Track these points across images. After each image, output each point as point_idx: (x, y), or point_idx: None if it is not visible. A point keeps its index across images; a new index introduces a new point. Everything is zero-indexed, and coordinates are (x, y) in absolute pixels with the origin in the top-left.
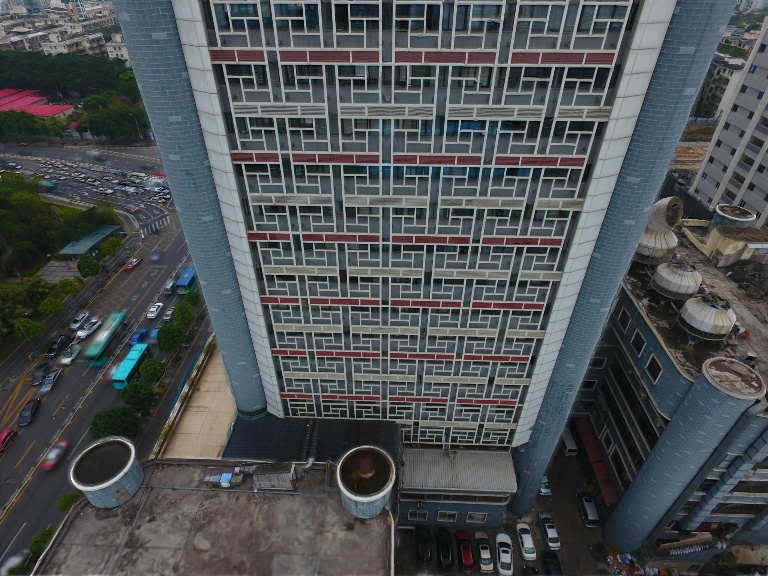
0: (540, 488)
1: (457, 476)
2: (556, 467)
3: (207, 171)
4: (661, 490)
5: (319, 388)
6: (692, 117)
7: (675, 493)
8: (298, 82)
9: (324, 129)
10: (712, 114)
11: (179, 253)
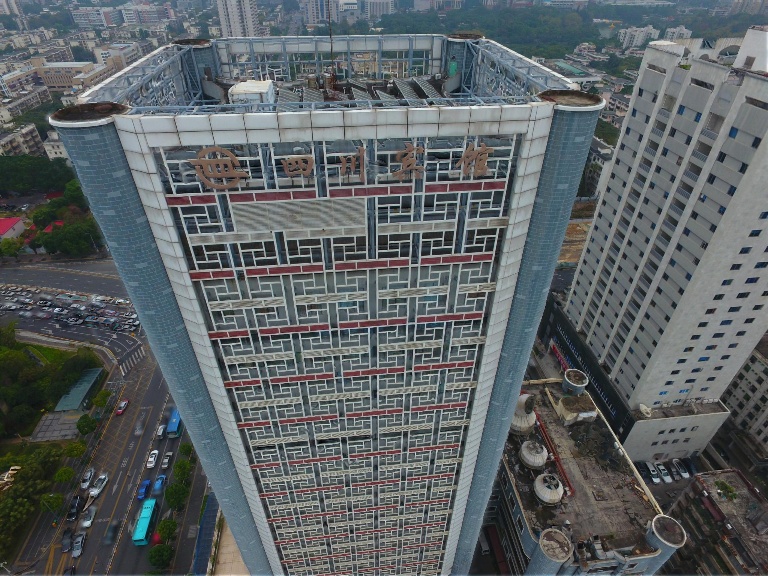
0: None
1: None
2: (476, 565)
3: (244, 498)
4: None
5: (312, 573)
6: (577, 197)
7: None
8: (298, 469)
9: None
10: (593, 192)
11: (161, 390)
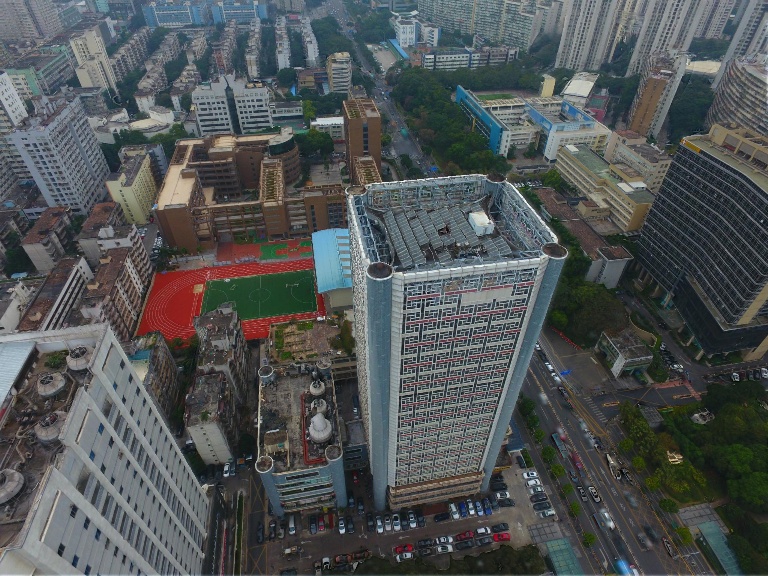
0: None
1: None
2: None
3: None
4: None
5: None
6: None
7: None
8: None
9: None
10: None
11: (653, 574)
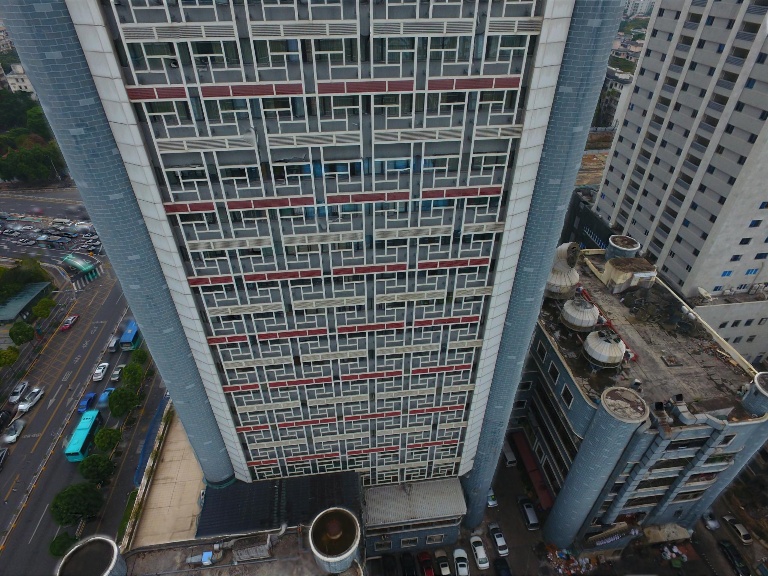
0: (488, 501)
1: (414, 507)
2: (500, 479)
3: (166, 293)
4: (582, 496)
5: (283, 453)
6: (593, 127)
7: (593, 497)
8: (245, 223)
9: (270, 252)
10: (609, 123)
11: (118, 305)
